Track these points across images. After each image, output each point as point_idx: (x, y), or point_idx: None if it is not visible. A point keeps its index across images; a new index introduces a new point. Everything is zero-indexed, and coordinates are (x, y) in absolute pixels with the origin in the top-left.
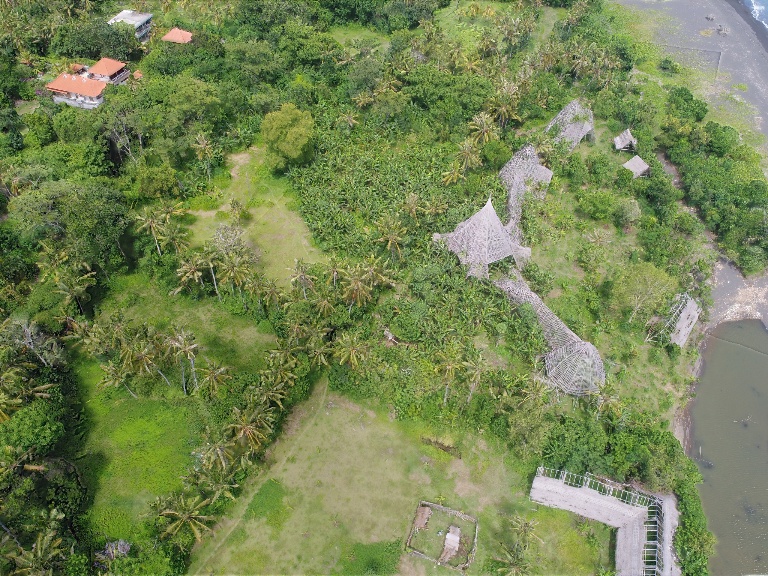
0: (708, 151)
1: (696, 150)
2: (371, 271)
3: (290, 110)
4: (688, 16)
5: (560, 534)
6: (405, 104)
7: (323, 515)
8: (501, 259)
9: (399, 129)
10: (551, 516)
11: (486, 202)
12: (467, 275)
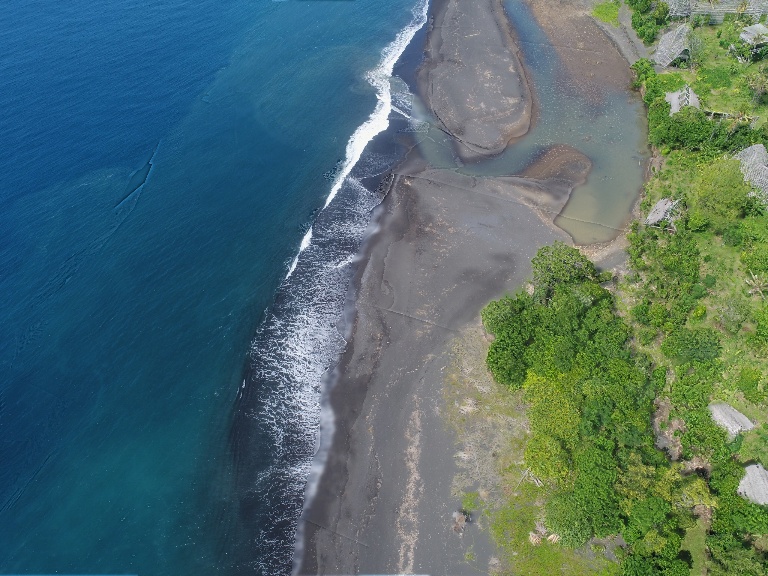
0: None
1: None
2: None
3: None
4: None
5: None
6: None
7: None
8: None
9: None
10: None
11: None
12: None
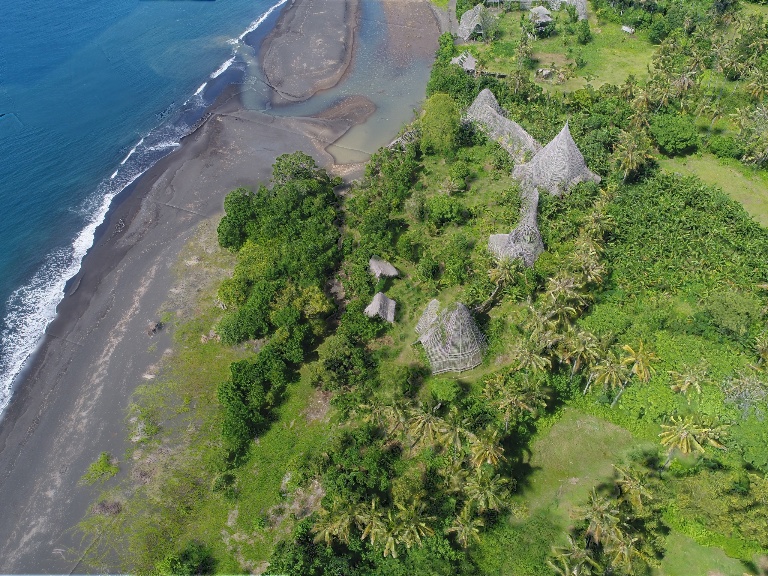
0: None
1: None
2: None
3: None
4: None
5: None
6: None
7: None
8: None
9: None
10: None
11: (558, 220)
12: None
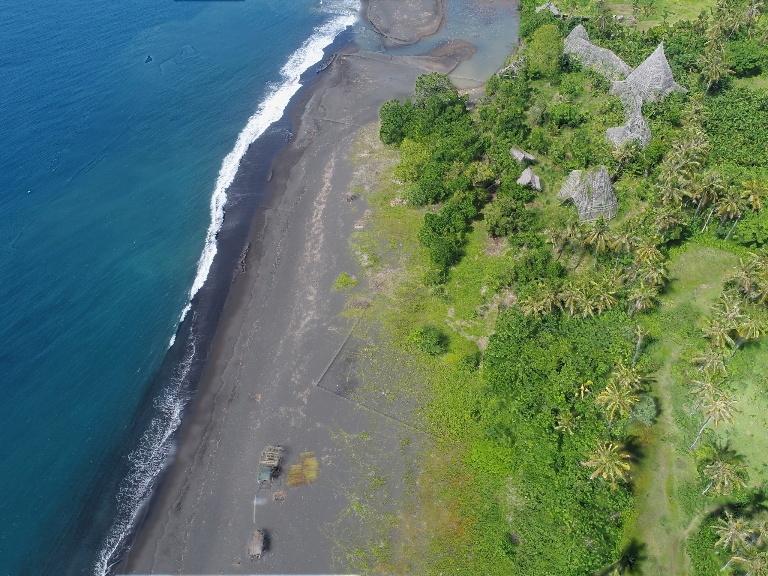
0: None
1: None
2: None
3: None
4: (302, 570)
5: None
6: None
7: None
8: None
9: None
10: None
11: None
12: None
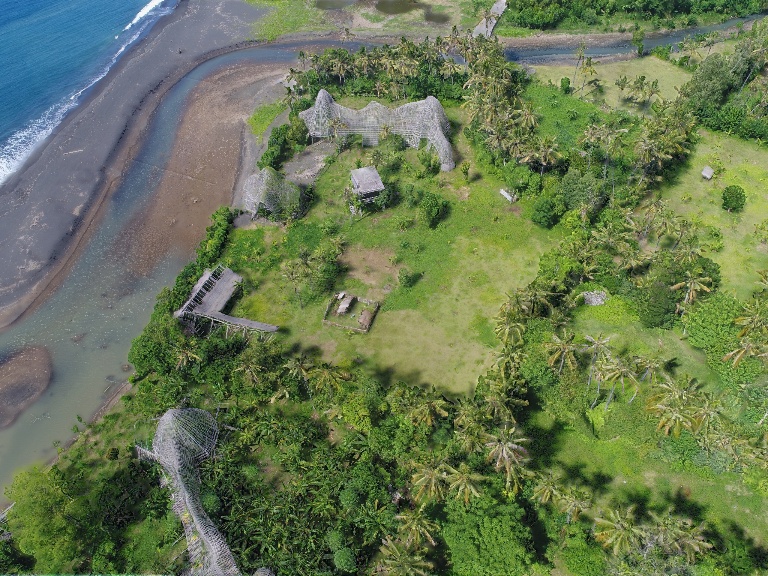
0: None
1: None
2: None
3: None
4: None
5: None
6: None
7: (444, 325)
8: None
9: None
10: None
11: None
12: None
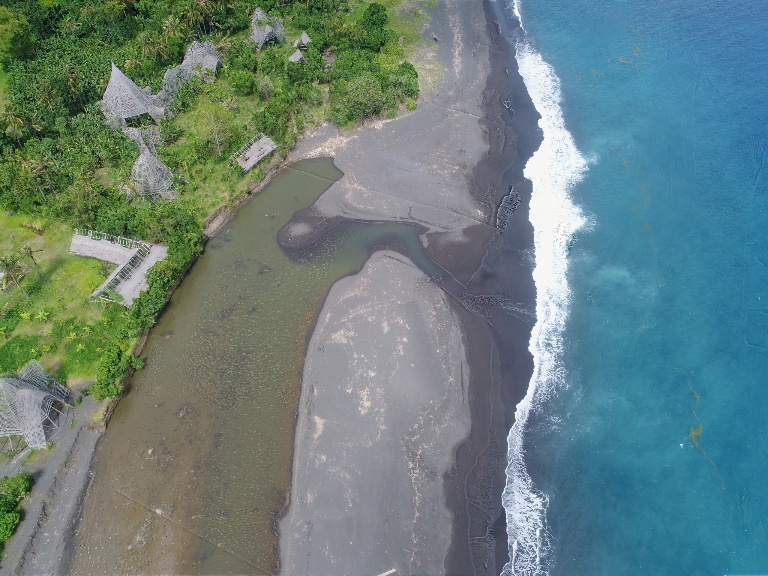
0: (364, 47)
1: (354, 47)
2: (10, 115)
3: (0, 11)
4: None
5: (86, 273)
6: (119, 13)
7: None
8: (138, 115)
9: (121, 36)
10: (85, 264)
11: None
12: (103, 125)
